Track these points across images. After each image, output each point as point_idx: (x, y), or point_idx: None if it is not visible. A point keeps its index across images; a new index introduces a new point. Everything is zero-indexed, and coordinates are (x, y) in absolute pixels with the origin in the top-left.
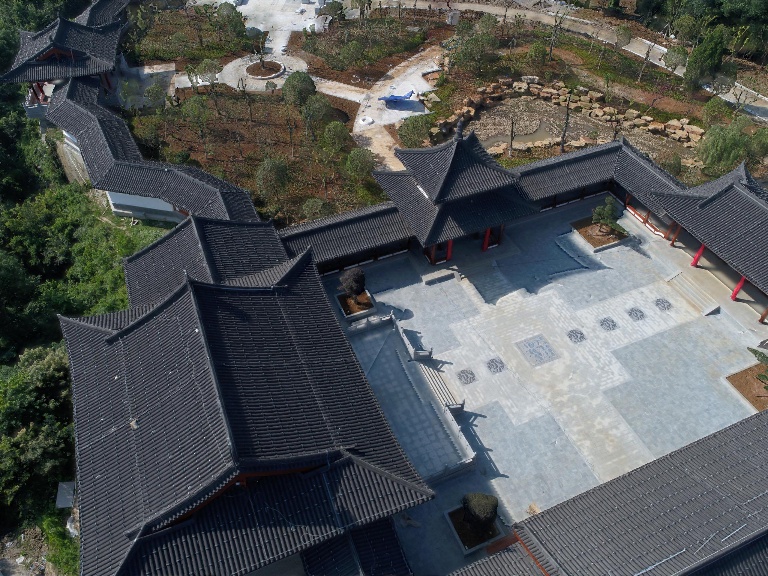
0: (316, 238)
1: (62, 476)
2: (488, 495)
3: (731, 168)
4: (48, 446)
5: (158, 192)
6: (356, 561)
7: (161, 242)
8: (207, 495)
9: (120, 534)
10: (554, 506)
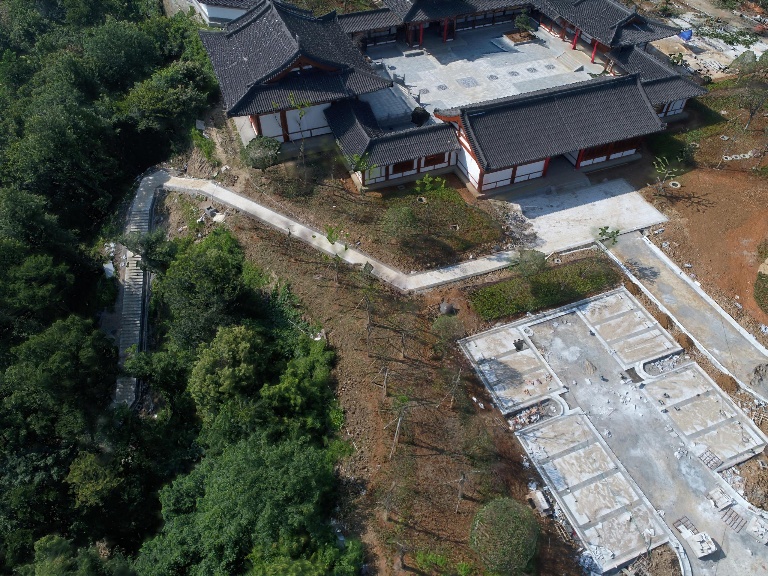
0: None
1: (198, 116)
2: None
3: None
4: (193, 96)
5: (240, 4)
6: (354, 116)
7: (248, 14)
8: (285, 68)
9: (243, 90)
10: None
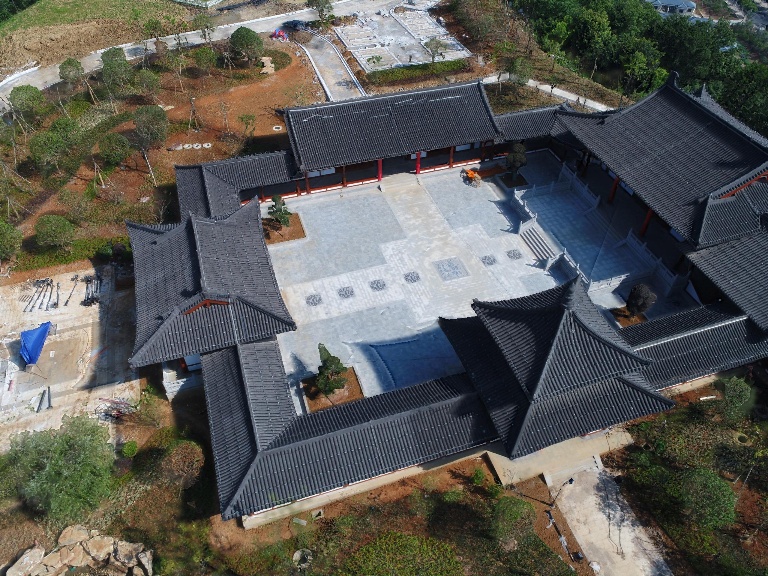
0: (705, 324)
1: None
2: (512, 159)
3: (29, 527)
4: None
5: None
6: None
7: None
8: None
9: None
10: (480, 140)
